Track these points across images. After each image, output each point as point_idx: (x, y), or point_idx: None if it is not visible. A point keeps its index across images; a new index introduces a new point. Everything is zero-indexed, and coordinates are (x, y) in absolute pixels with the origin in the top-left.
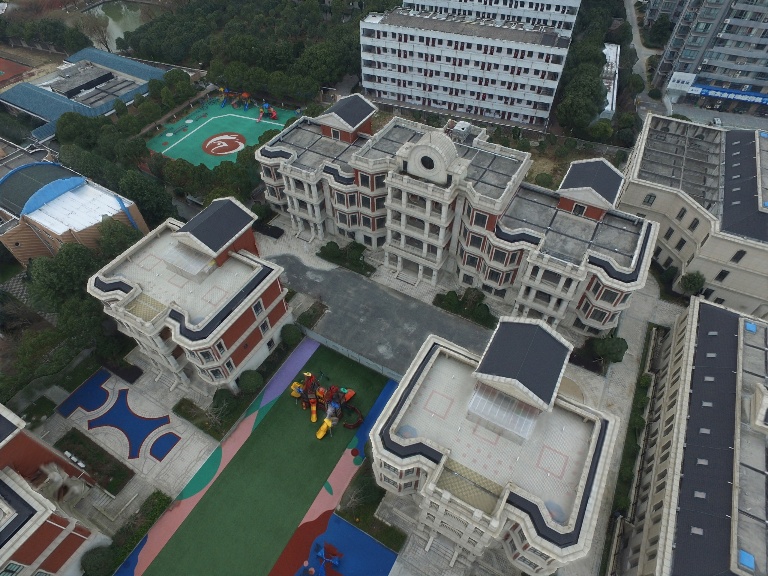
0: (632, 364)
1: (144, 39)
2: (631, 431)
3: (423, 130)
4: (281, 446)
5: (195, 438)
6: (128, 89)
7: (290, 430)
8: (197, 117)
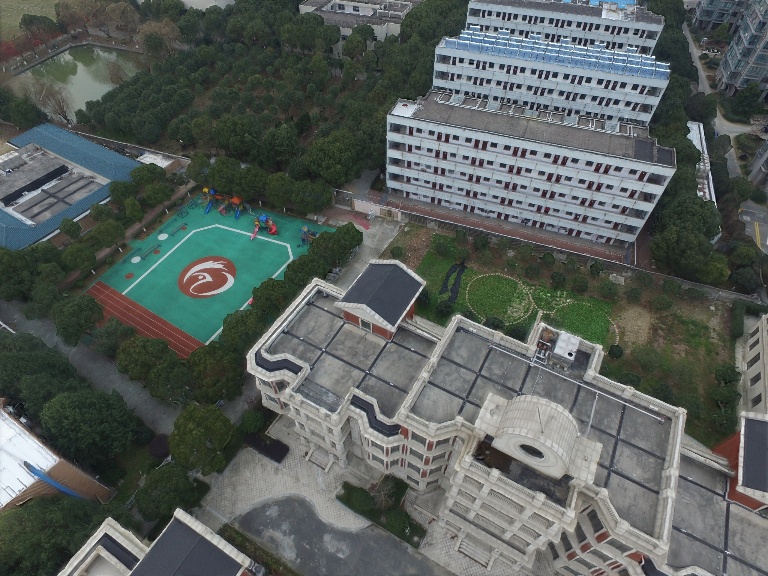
0: None
1: (110, 113)
2: None
3: (503, 342)
4: None
5: None
6: (84, 192)
7: None
8: (173, 231)
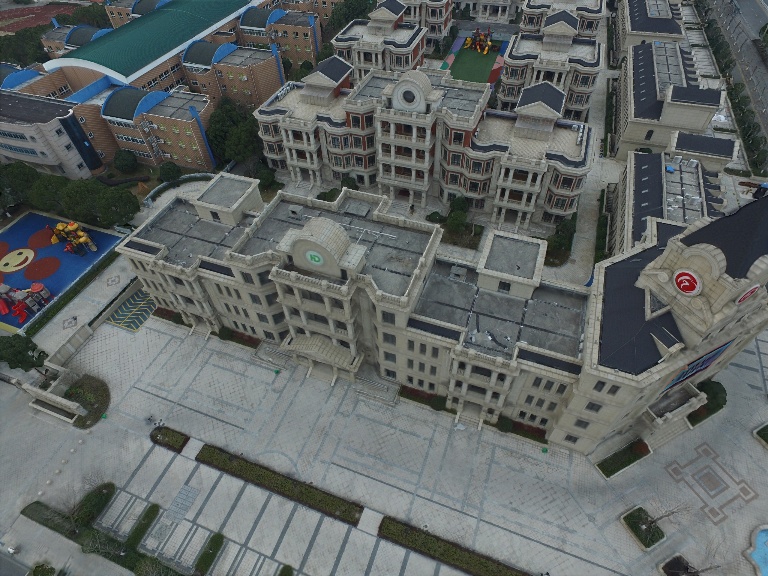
0: (604, 27)
1: None
2: (609, 39)
3: None
4: (470, 58)
5: (432, 61)
6: None
7: (471, 55)
8: None
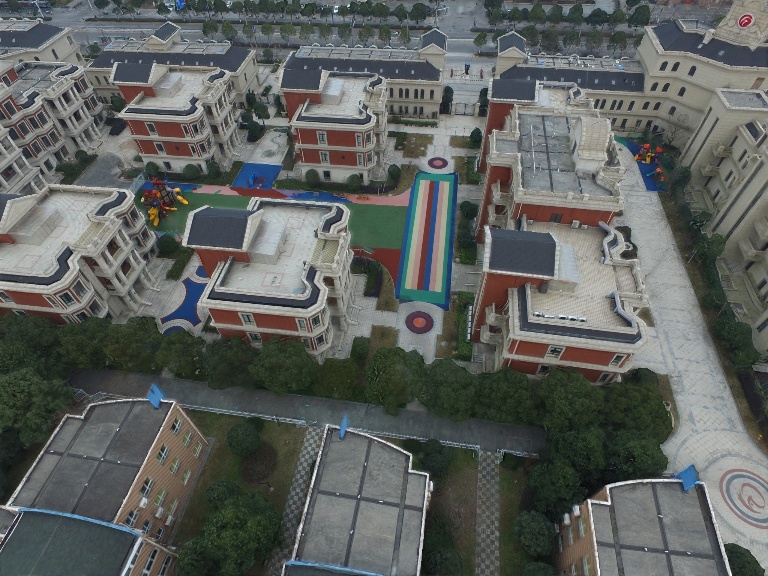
0: None
1: None
2: None
3: None
4: None
5: (198, 258)
6: None
7: (184, 218)
8: None
